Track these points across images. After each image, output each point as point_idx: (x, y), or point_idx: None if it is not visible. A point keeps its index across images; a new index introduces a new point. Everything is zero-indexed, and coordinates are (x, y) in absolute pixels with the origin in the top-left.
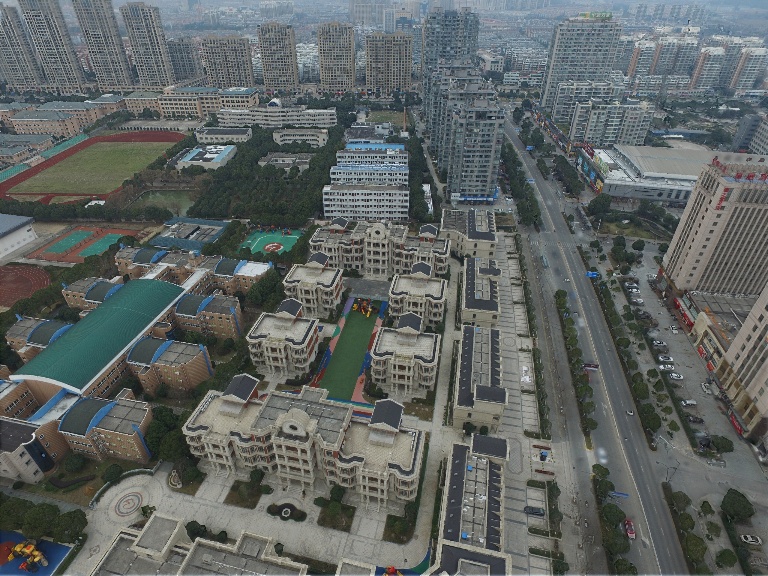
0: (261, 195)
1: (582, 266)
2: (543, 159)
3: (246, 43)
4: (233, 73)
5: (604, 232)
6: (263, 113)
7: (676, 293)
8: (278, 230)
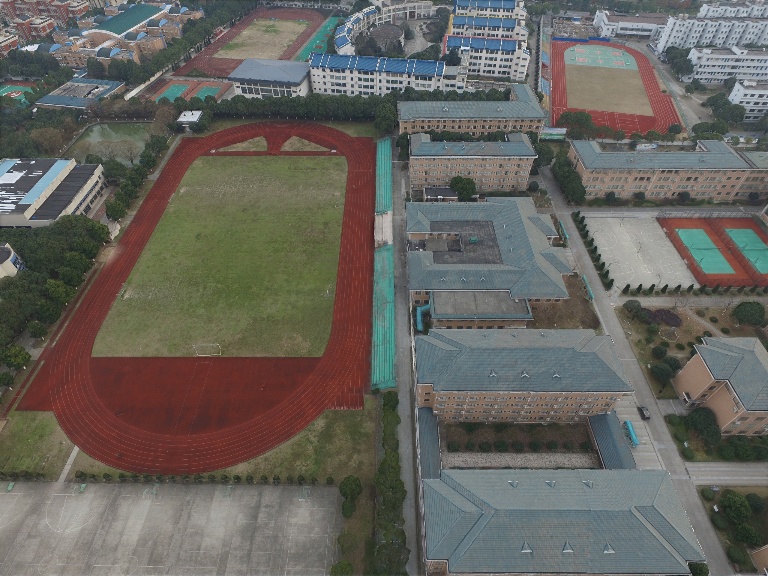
0: None
1: None
2: None
3: None
4: None
5: None
6: None
7: None
8: None
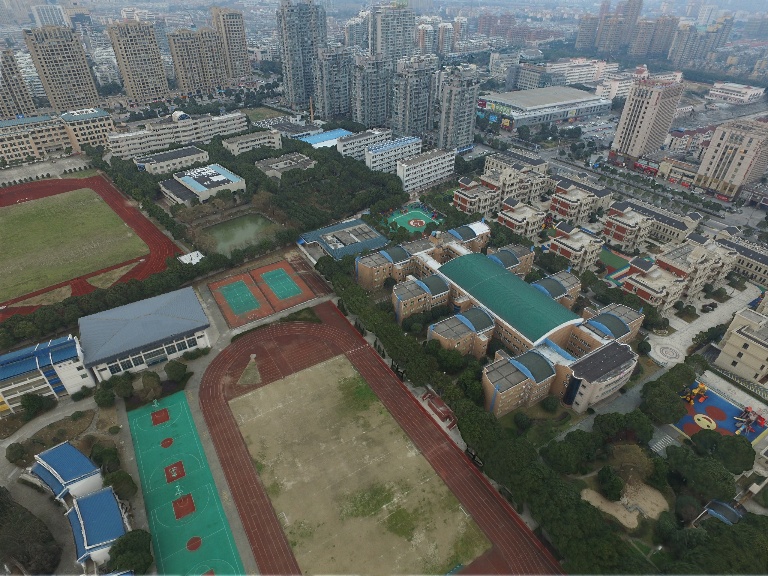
0: (322, 196)
1: (572, 166)
2: (435, 118)
3: (12, 56)
4: (3, 98)
5: (547, 148)
6: (173, 129)
7: (635, 160)
8: (394, 212)
